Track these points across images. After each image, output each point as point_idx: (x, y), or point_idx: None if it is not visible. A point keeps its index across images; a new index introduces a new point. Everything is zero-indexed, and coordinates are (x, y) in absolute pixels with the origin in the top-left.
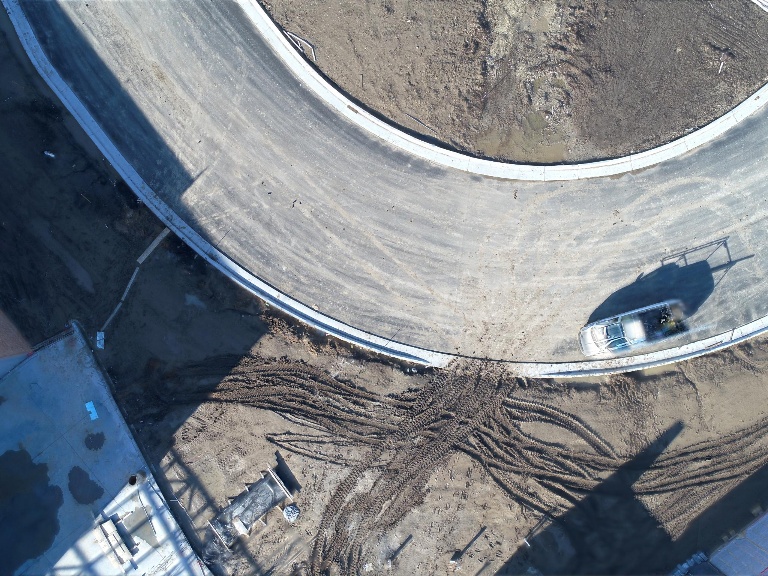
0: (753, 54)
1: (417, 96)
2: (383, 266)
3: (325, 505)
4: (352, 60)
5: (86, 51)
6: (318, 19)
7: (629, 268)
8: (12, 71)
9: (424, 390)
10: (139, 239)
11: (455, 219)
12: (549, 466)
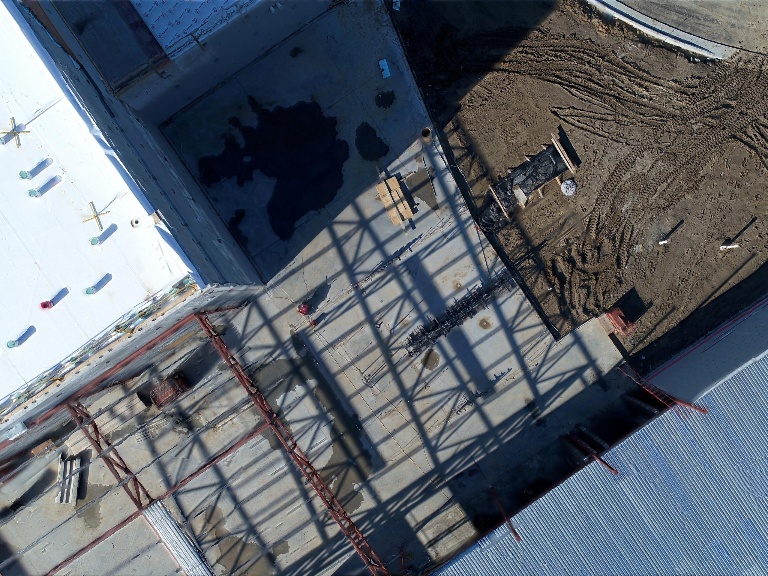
0: None
1: None
2: None
3: (602, 182)
4: None
5: None
6: None
7: None
8: None
9: (706, 79)
10: None
11: None
12: None
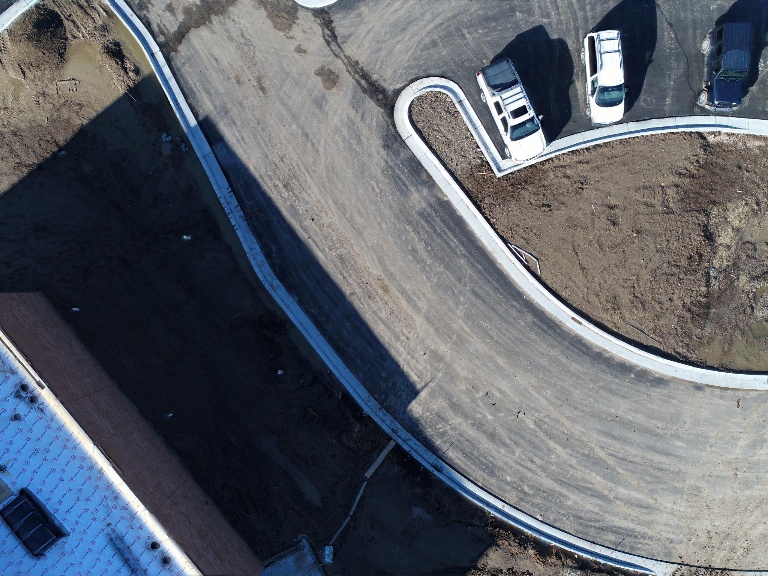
0: None
1: (642, 308)
2: (607, 476)
3: None
4: (577, 273)
5: (312, 265)
6: (543, 233)
7: None
8: (240, 287)
9: None
10: (366, 453)
11: (678, 428)
12: None
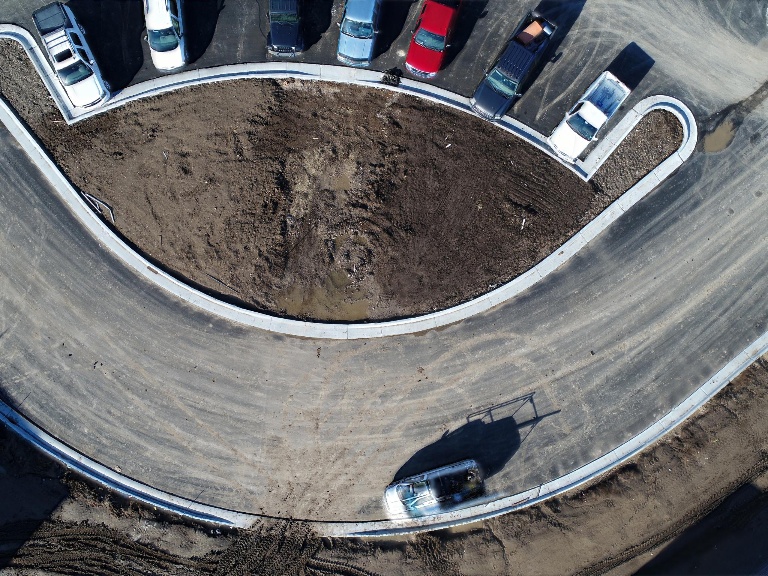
0: (555, 210)
1: (217, 257)
2: (186, 427)
3: None
4: (150, 221)
5: None
6: (116, 181)
7: (434, 425)
8: None
9: (228, 552)
10: None
11: (258, 378)
12: None
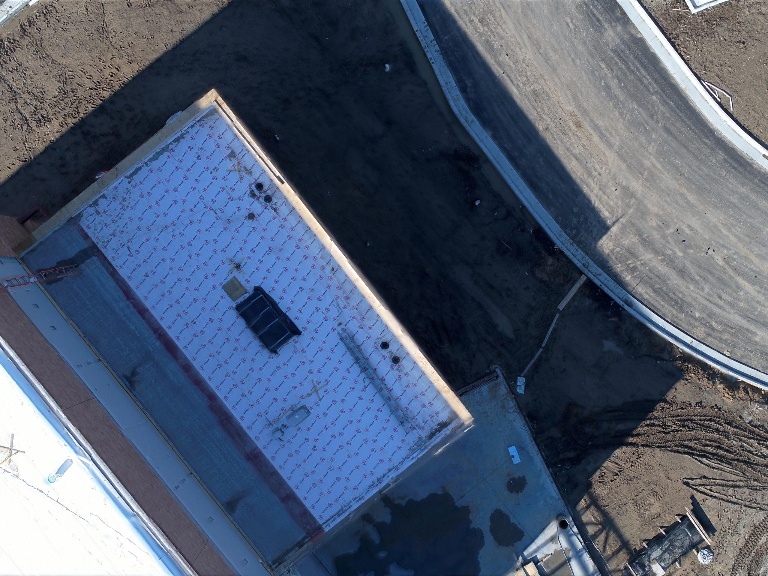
0: None
1: None
2: None
3: (738, 548)
4: None
5: (506, 100)
6: (737, 69)
7: None
8: (435, 120)
9: None
10: (558, 286)
11: None
12: None
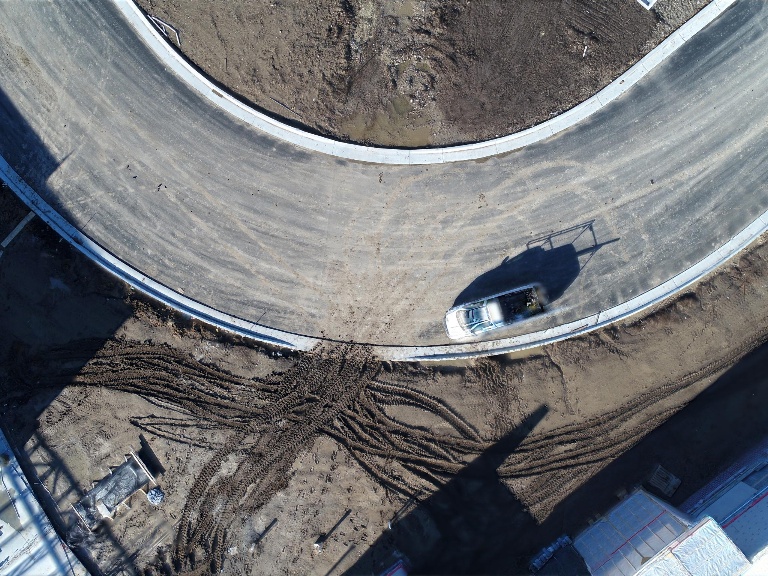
0: (617, 38)
1: (281, 80)
2: (248, 250)
3: (189, 488)
4: (216, 44)
5: None
6: (182, 4)
7: (494, 251)
8: None
9: (289, 373)
10: (4, 223)
11: (320, 203)
12: (414, 449)
